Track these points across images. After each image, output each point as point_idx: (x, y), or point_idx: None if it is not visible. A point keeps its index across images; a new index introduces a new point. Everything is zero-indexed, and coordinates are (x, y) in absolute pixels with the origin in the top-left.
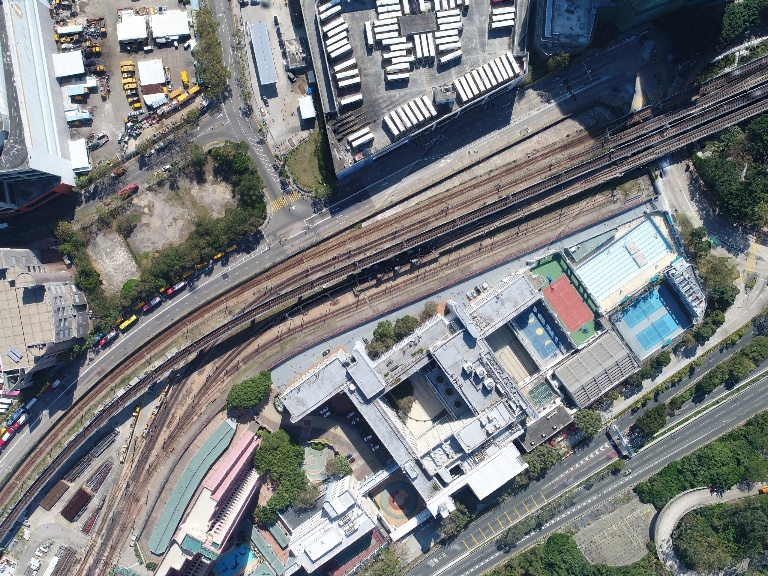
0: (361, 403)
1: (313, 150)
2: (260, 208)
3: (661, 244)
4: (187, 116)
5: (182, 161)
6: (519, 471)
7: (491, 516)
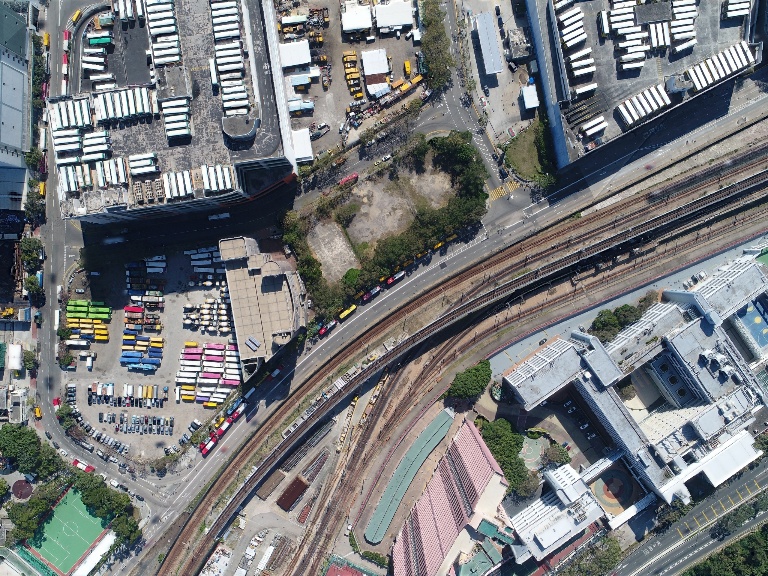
0: (595, 391)
1: (533, 140)
2: (484, 197)
3: None
4: (410, 106)
5: (402, 151)
6: (754, 458)
7: (705, 504)
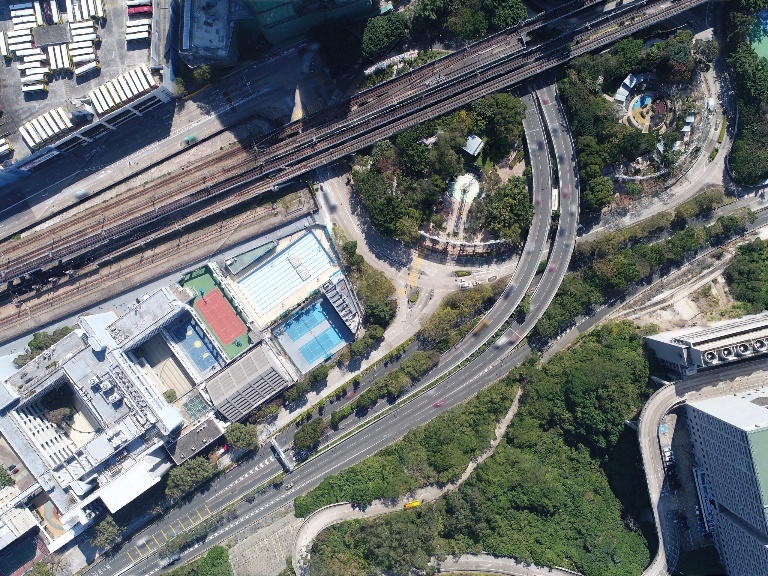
0: None
1: None
2: None
3: (324, 257)
4: None
5: None
6: (151, 485)
7: (155, 528)
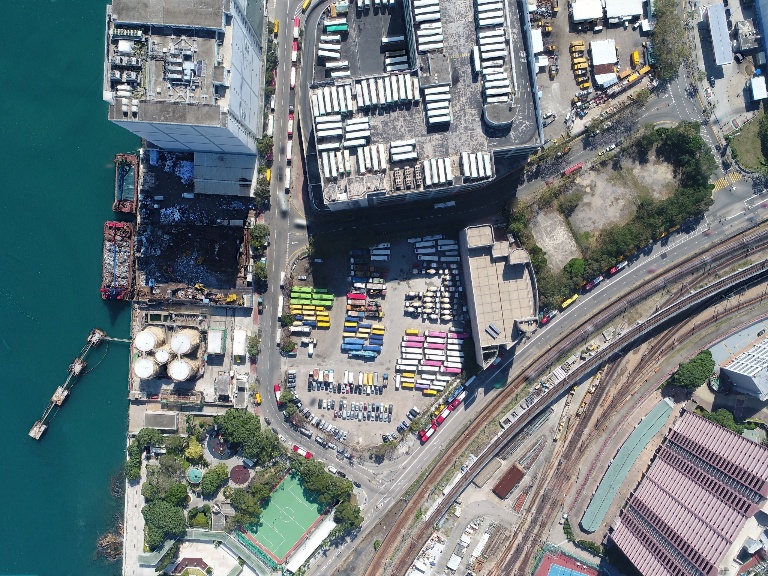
0: None
1: (757, 131)
2: (711, 188)
3: None
4: (637, 96)
5: (626, 141)
6: None
7: None
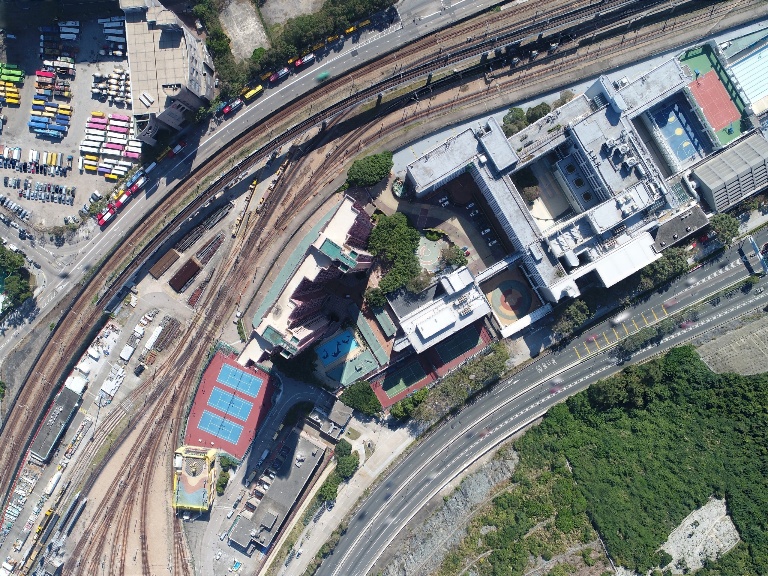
0: (490, 178)
1: None
2: None
3: None
4: None
5: None
6: (652, 260)
7: (607, 325)
